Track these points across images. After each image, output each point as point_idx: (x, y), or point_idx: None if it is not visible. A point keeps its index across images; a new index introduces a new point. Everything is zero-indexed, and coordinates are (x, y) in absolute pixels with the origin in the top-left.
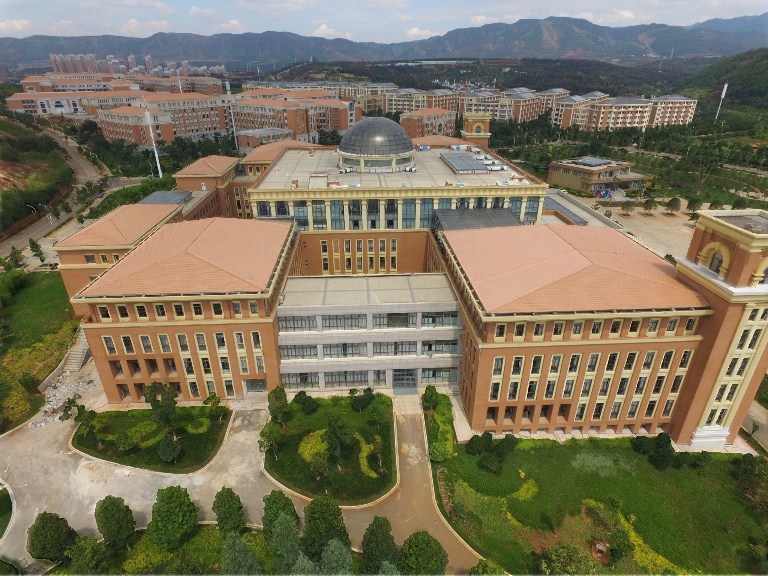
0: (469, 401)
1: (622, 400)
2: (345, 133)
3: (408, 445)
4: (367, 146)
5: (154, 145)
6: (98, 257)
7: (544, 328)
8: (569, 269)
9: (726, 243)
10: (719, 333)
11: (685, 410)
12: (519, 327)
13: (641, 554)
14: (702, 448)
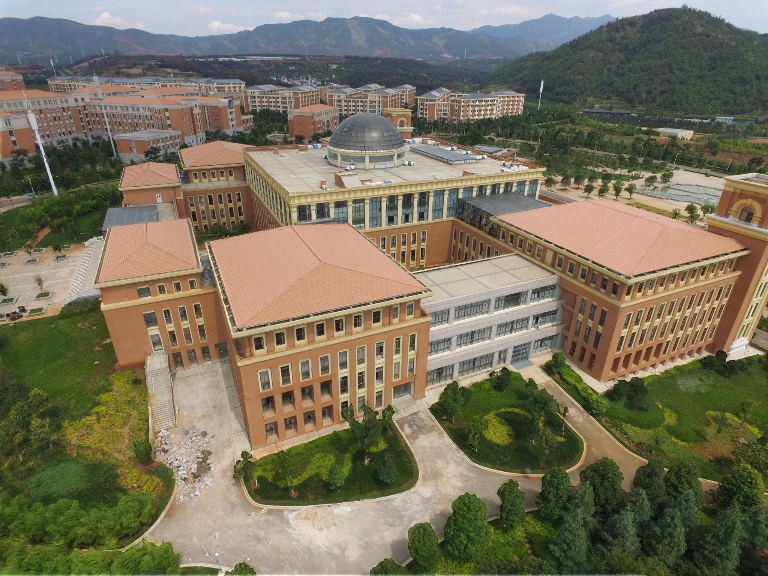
0: (589, 359)
1: (690, 332)
2: (338, 130)
3: None
4: (371, 142)
5: (43, 155)
6: (154, 288)
7: (655, 283)
8: (651, 233)
9: (755, 199)
10: (758, 266)
11: (727, 330)
12: (640, 285)
13: None
14: (734, 357)
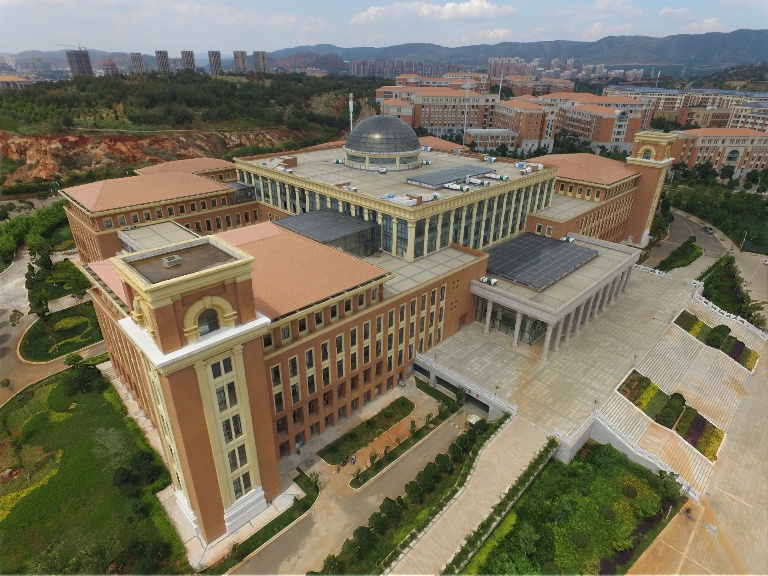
0: None
1: None
2: None
3: (88, 352)
4: (350, 140)
5: None
6: None
7: None
8: None
9: None
10: None
11: None
12: None
13: (8, 499)
14: (181, 516)
